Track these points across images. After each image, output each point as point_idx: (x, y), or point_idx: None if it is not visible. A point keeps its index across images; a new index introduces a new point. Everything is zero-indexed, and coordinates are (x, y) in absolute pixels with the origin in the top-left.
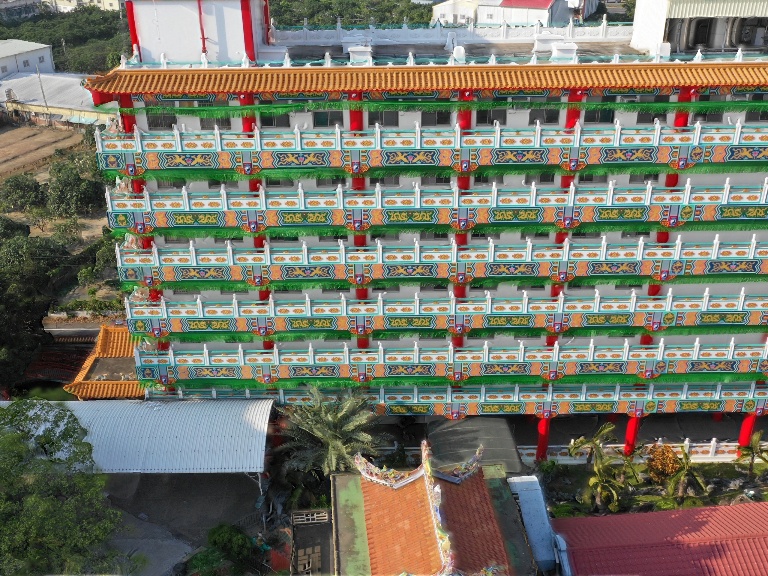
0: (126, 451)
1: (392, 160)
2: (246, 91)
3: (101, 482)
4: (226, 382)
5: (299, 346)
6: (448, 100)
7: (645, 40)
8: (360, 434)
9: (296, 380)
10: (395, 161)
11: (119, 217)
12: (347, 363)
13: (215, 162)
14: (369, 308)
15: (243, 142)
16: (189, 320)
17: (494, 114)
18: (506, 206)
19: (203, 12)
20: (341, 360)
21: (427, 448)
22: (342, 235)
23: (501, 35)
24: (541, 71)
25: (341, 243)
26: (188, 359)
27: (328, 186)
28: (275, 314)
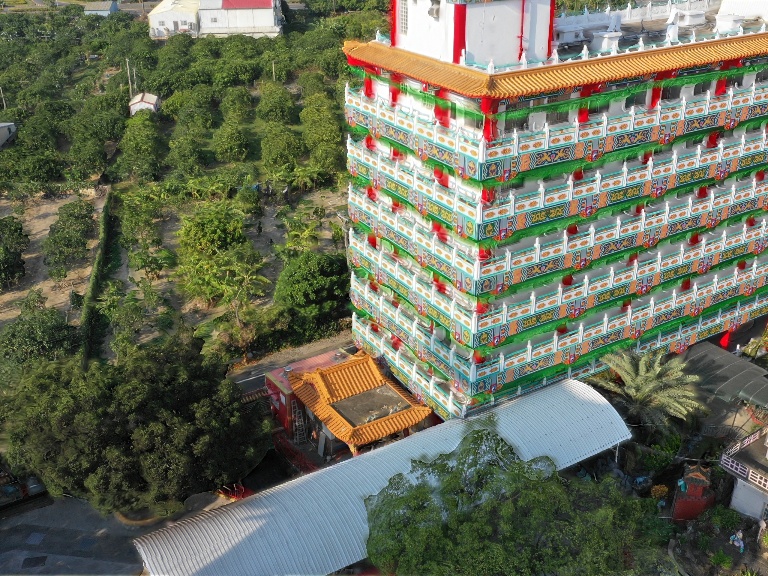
0: None
1: (690, 128)
2: (608, 80)
3: (611, 479)
4: (540, 373)
5: (593, 320)
6: (713, 70)
7: (751, 9)
8: (685, 377)
9: (591, 353)
10: (692, 128)
11: (488, 227)
12: (629, 324)
13: (572, 154)
14: (651, 268)
15: (594, 130)
16: (524, 319)
17: (736, 78)
18: (748, 154)
19: (524, 10)
20: (625, 323)
21: None
22: (627, 207)
23: (627, 16)
24: None
25: (643, 212)
26: (514, 360)
27: None
28: (587, 293)
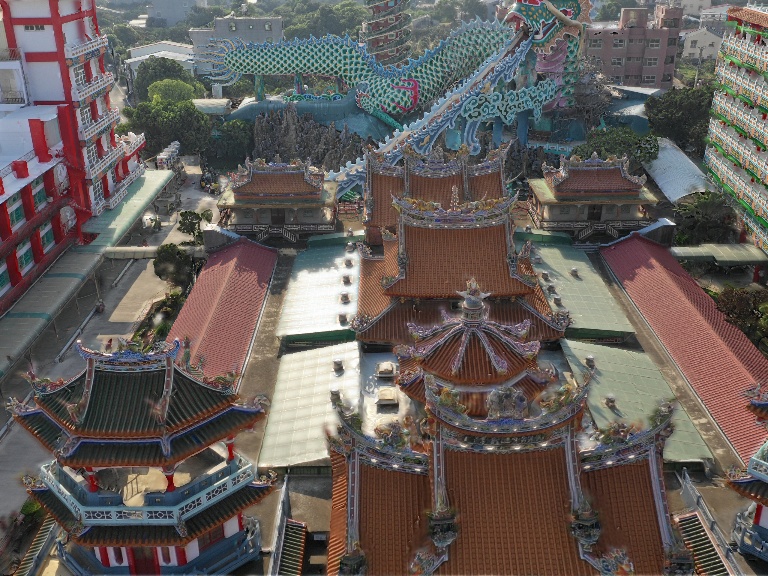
0: (666, 178)
1: None
2: (749, 22)
3: None
4: None
5: None
6: None
7: None
8: None
9: None
10: None
11: None
12: None
13: None
14: None
15: None
16: None
17: None
18: None
19: None
20: None
21: (623, 155)
22: None
23: None
24: None
25: None
26: None
27: (766, 82)
28: None
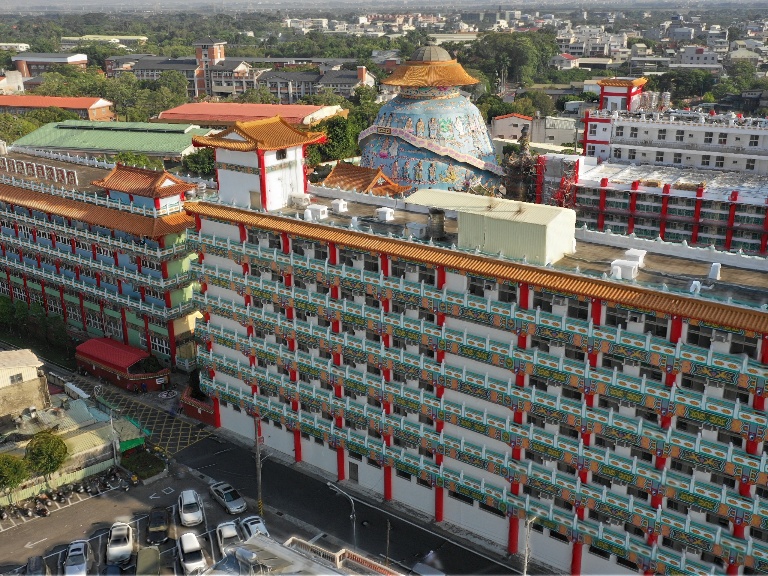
0: None
1: None
2: None
3: None
4: None
5: None
6: None
7: None
8: None
9: None
10: None
11: None
12: None
13: None
14: None
15: None
16: None
17: None
18: None
19: None
20: None
21: None
22: None
23: None
24: None
25: None
26: None
27: None
28: None
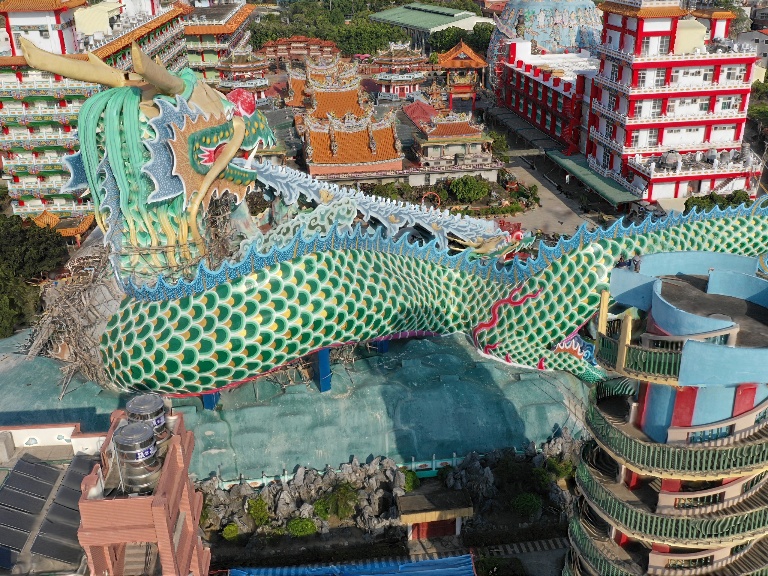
0: None
1: None
2: None
3: None
4: None
5: None
6: None
7: (93, 30)
8: None
9: None
10: None
11: None
12: None
13: None
14: None
15: None
16: None
17: None
18: None
19: None
20: None
21: None
22: None
23: None
24: (128, 36)
25: None
26: None
27: None
28: None
